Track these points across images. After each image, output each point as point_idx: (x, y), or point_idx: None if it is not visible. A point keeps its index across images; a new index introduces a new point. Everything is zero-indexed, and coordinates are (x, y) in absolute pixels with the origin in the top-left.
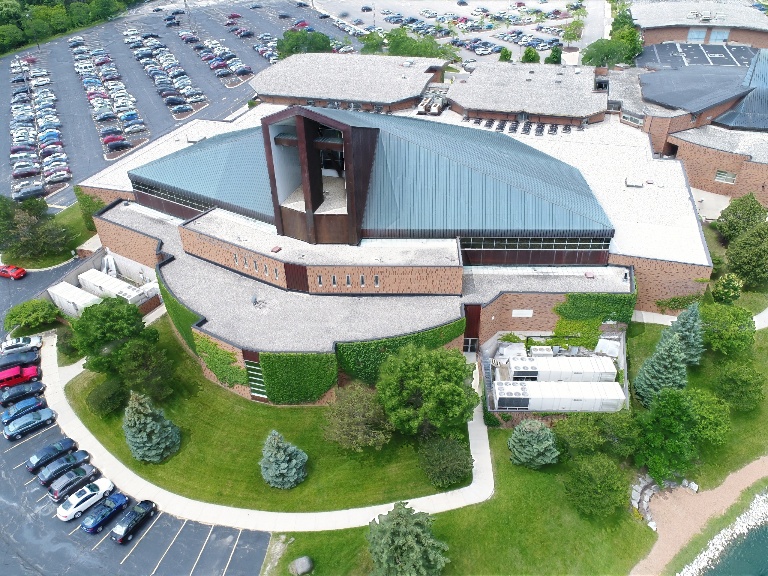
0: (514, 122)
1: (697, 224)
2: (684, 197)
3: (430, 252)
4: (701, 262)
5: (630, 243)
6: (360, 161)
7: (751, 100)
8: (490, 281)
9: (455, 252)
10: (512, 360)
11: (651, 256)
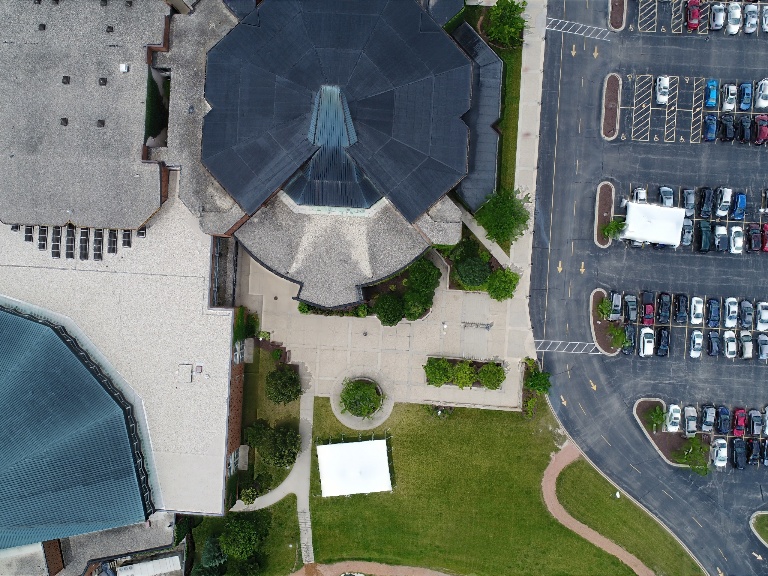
0: (68, 230)
1: (224, 450)
2: (223, 397)
3: (26, 561)
4: (217, 510)
5: (172, 491)
6: None
7: (317, 164)
8: (81, 544)
9: (42, 558)
10: (119, 572)
11: (184, 508)
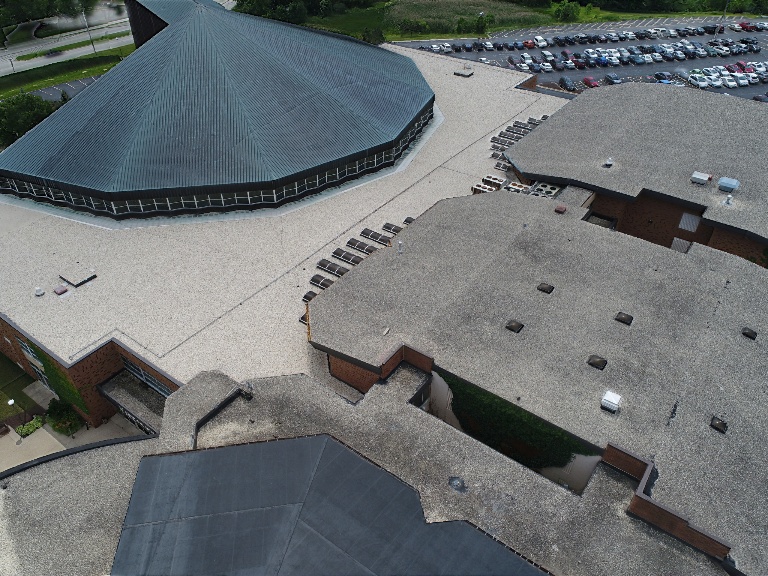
0: None
1: None
2: None
3: None
4: None
5: None
6: (141, 28)
7: None
8: None
9: None
10: None
11: None
